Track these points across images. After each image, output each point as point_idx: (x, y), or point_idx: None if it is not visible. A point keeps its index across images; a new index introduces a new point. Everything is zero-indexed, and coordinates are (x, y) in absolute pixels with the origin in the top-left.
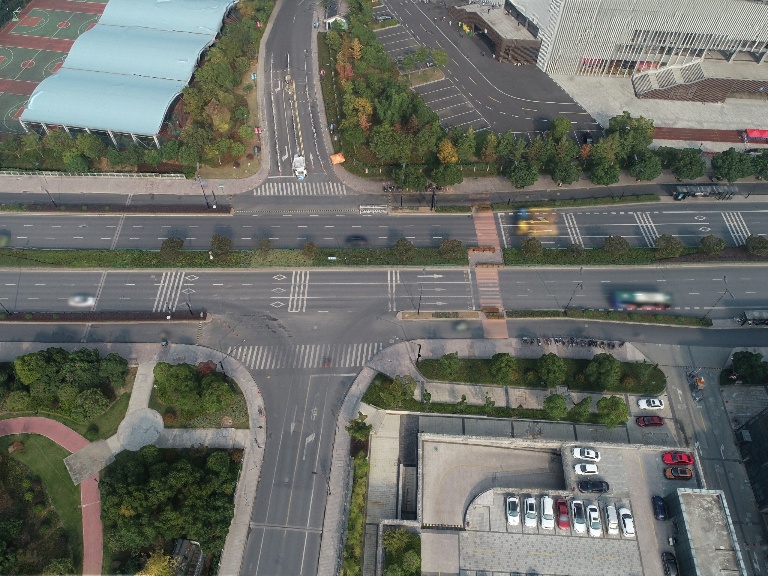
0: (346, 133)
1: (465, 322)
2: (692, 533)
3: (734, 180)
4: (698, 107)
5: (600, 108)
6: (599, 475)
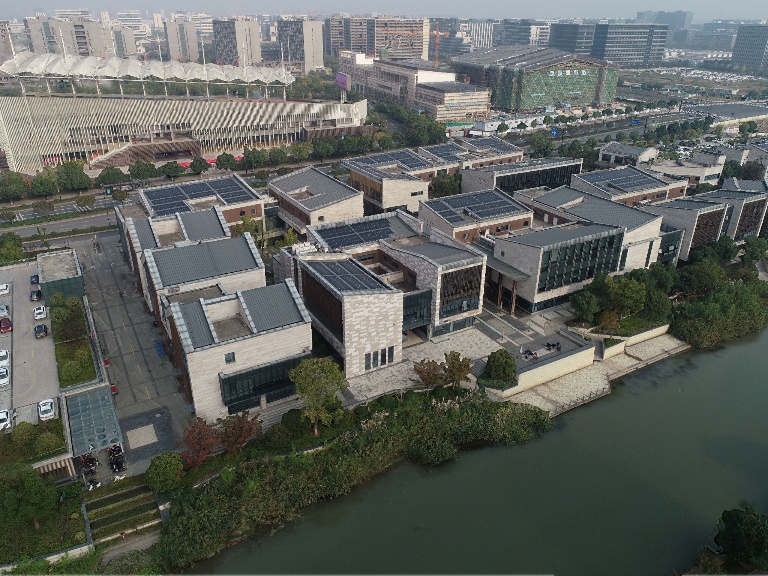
0: None
1: None
2: (44, 267)
3: (146, 177)
4: None
5: None
6: None
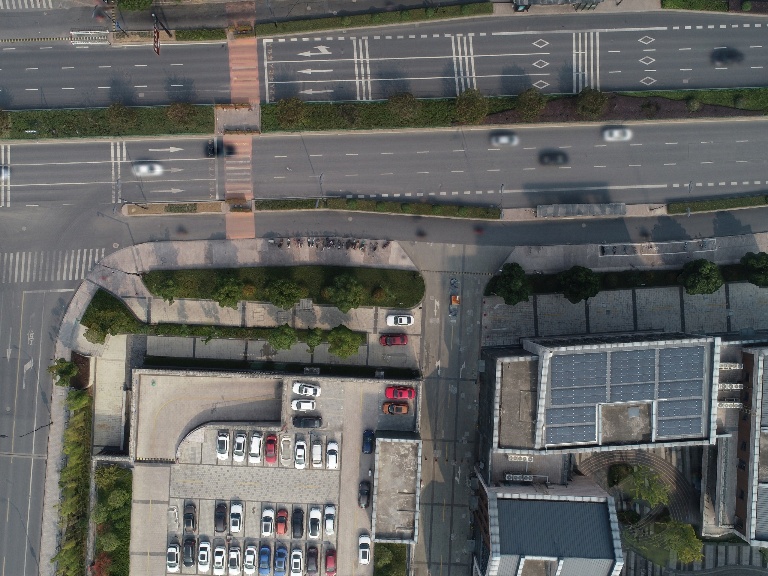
0: None
1: (204, 217)
2: (381, 478)
3: None
4: None
5: None
6: (317, 409)
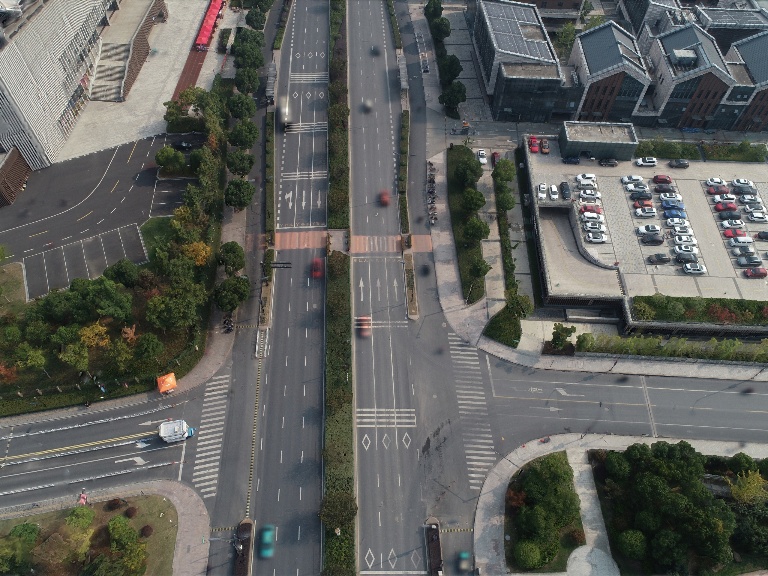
0: (150, 353)
1: (416, 265)
2: None
3: None
4: (151, 66)
5: (131, 131)
6: None
